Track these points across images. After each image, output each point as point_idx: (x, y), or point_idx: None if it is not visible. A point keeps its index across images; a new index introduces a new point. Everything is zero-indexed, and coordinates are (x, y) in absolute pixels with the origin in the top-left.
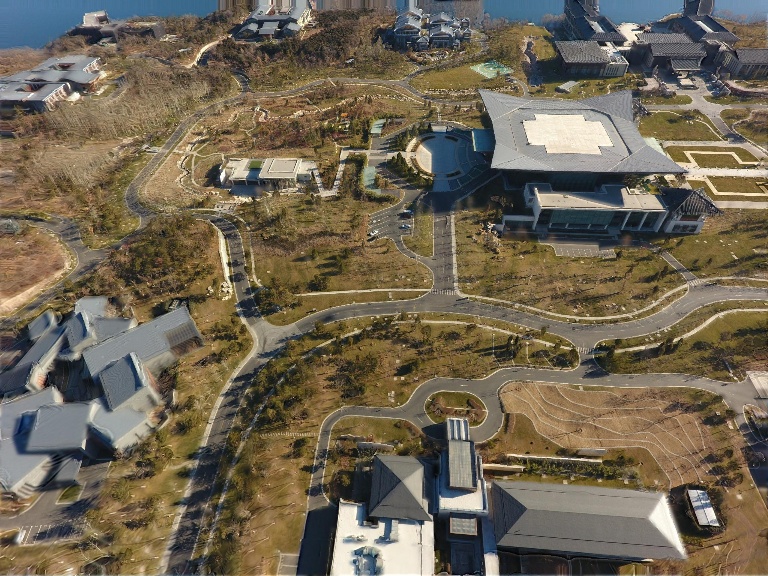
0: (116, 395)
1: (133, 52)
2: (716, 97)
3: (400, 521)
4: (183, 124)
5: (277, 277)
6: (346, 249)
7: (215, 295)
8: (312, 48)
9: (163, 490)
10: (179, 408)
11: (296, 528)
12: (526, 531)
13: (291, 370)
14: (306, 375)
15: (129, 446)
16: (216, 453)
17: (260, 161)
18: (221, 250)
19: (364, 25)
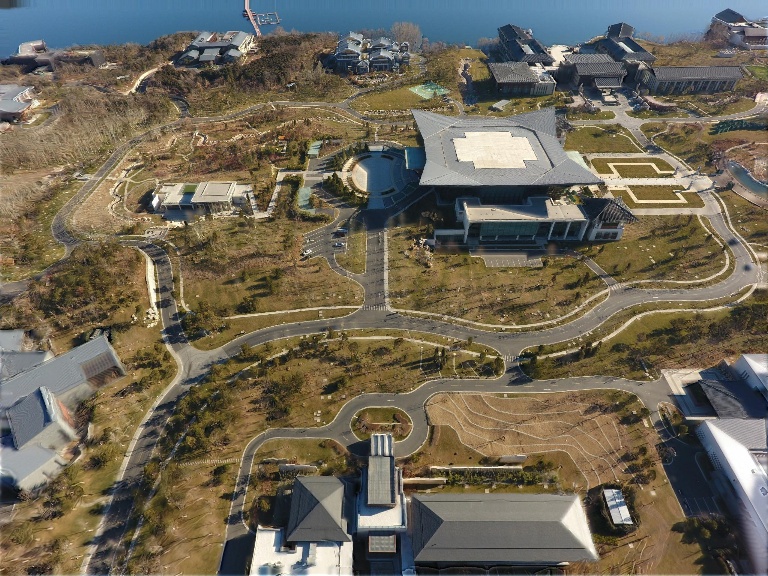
0: (22, 433)
1: (70, 80)
2: (637, 112)
3: (318, 544)
4: (118, 151)
5: (204, 301)
6: (277, 270)
7: (140, 322)
8: (253, 73)
9: (72, 531)
10: (94, 442)
11: (212, 560)
12: (443, 544)
13: (215, 395)
14: (228, 399)
15: (36, 486)
16: (132, 487)
17: (195, 185)
18: (148, 276)
19: (306, 50)
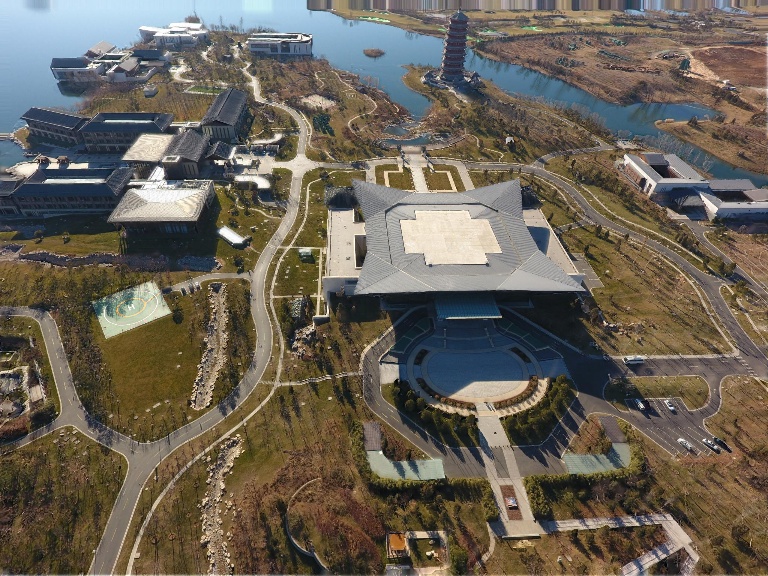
0: None
1: None
2: (281, 156)
3: None
4: None
5: None
6: None
7: None
8: None
9: None
10: None
11: None
12: None
13: None
14: None
15: None
16: None
17: None
18: None
19: None
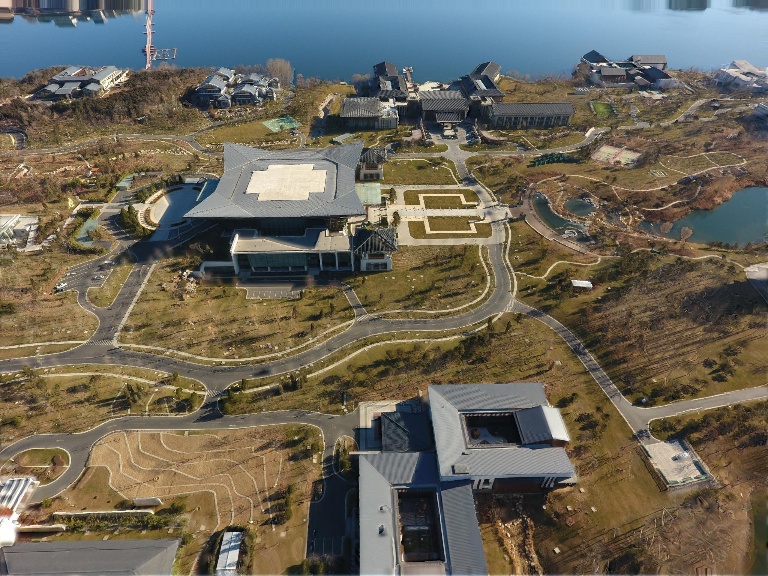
0: None
1: None
2: (469, 145)
3: None
4: None
5: None
6: (9, 304)
7: None
8: (103, 107)
9: None
10: None
11: None
12: None
13: None
14: None
15: None
16: None
17: None
18: None
19: (178, 85)
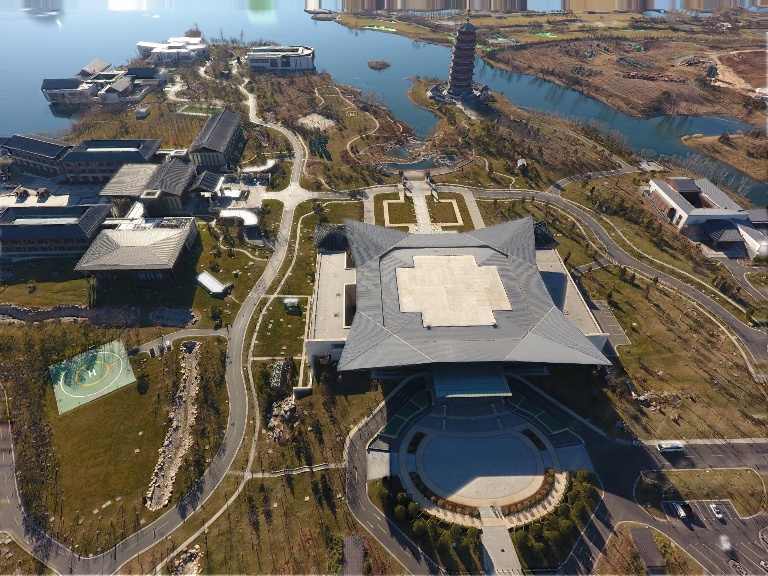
0: None
1: None
2: (273, 185)
3: None
4: None
5: None
6: None
7: None
8: None
9: None
10: None
11: None
12: None
13: None
14: None
15: None
16: None
17: None
18: None
19: None
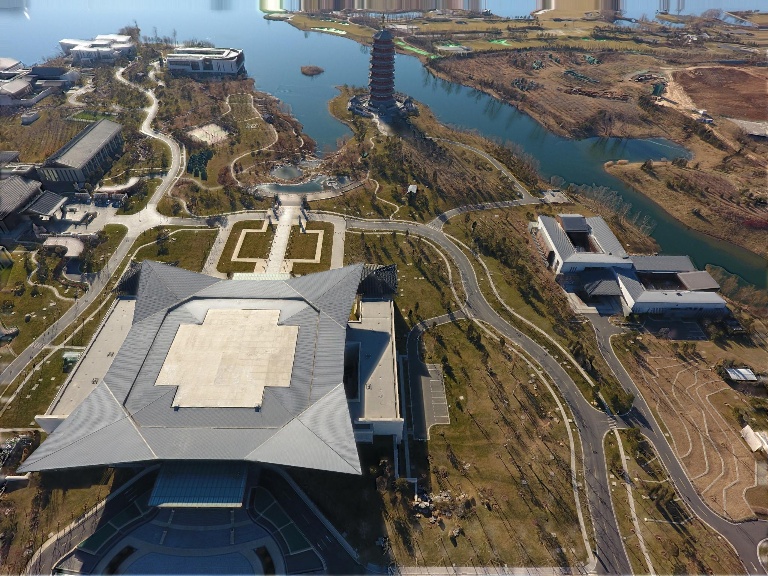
0: None
1: None
2: (126, 207)
3: None
4: None
5: None
6: None
7: None
8: None
9: None
10: None
11: None
12: None
13: None
14: None
15: None
16: None
17: None
18: None
19: None
